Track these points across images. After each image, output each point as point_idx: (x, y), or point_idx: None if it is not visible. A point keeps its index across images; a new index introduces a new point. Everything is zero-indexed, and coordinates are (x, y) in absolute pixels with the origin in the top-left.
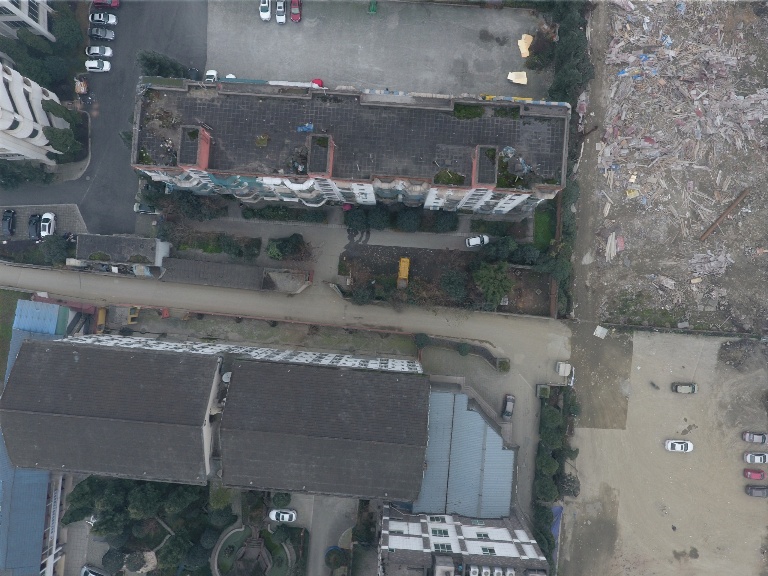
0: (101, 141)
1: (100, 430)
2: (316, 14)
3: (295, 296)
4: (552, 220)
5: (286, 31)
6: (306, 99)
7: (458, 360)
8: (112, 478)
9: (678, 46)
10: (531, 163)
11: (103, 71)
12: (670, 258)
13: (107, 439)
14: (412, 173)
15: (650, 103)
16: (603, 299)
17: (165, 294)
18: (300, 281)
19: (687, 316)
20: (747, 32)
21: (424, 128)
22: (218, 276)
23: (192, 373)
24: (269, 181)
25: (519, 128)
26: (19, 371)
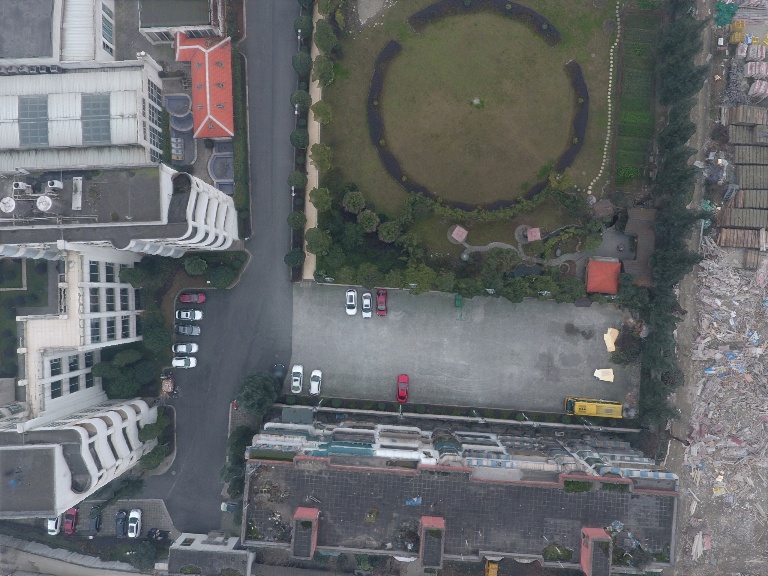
0: (187, 436)
1: None
2: (401, 307)
3: None
4: None
5: (371, 324)
6: None
7: None
8: None
9: (765, 342)
10: (639, 538)
11: (189, 367)
12: (756, 557)
13: None
14: (520, 547)
15: (736, 399)
16: None
17: None
18: None
19: None
20: None
21: (532, 502)
22: None
23: None
24: None
25: (627, 502)
26: None
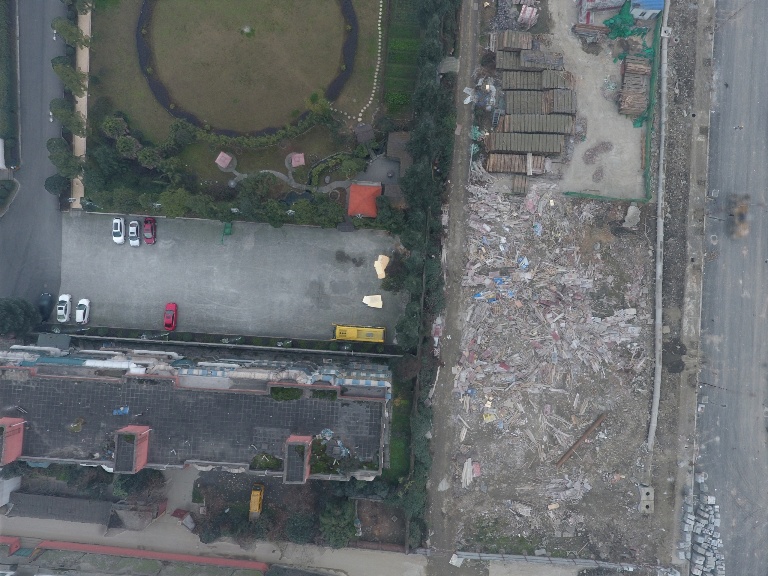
0: None
1: None
2: (171, 236)
3: None
4: (407, 447)
5: (141, 253)
6: None
7: None
8: None
9: (535, 267)
10: (349, 446)
11: None
12: (527, 483)
13: None
14: (229, 456)
15: (507, 325)
16: (459, 526)
17: (17, 523)
18: (147, 519)
19: (544, 544)
20: (604, 252)
21: (241, 410)
22: (66, 511)
23: None
24: None
25: (337, 410)
26: None
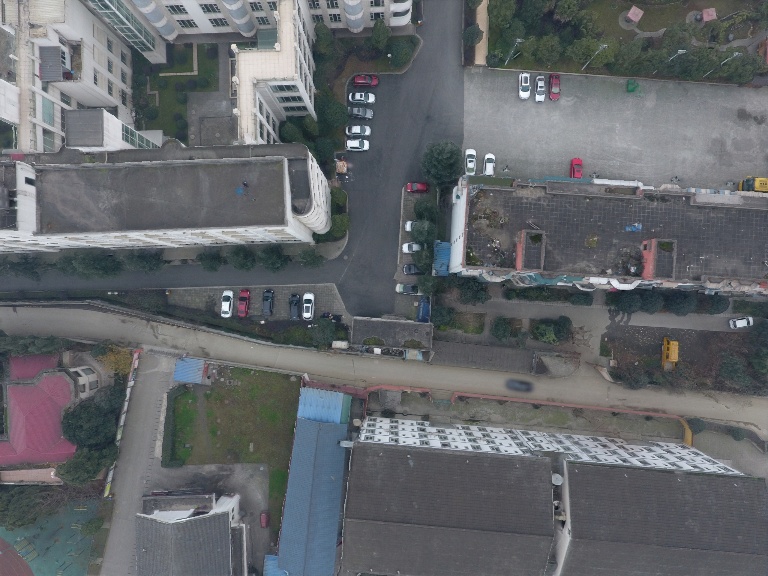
0: (359, 220)
1: (447, 539)
2: (573, 92)
3: None
4: None
5: (543, 109)
6: (635, 199)
7: (724, 443)
8: None
9: None
10: None
11: (362, 150)
12: None
13: (451, 547)
14: (741, 273)
15: None
16: None
17: (426, 375)
18: (573, 365)
19: None
20: None
21: (753, 228)
22: (487, 359)
23: (529, 478)
24: (595, 280)
25: None
26: (358, 477)
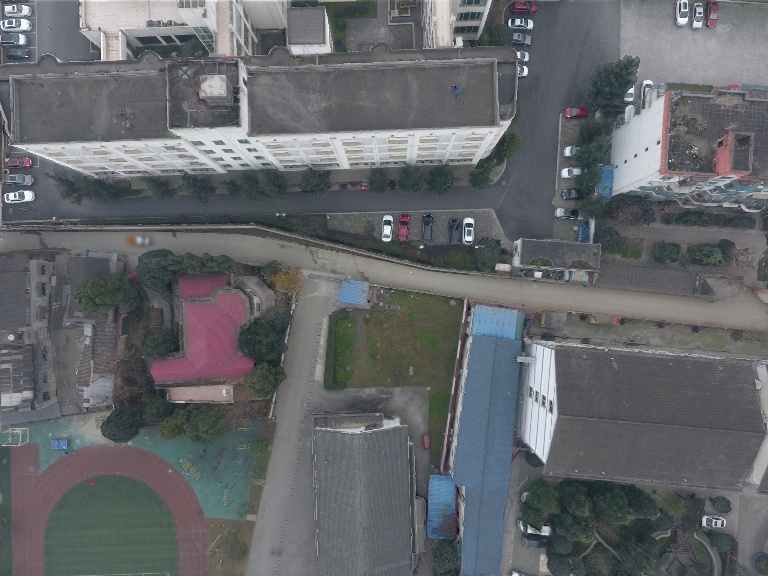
0: None
1: (658, 437)
2: (729, 20)
3: (716, 302)
4: None
5: (699, 37)
6: None
7: None
8: (558, 484)
9: None
10: None
11: (521, 76)
12: None
13: (661, 446)
14: None
15: None
16: None
17: (584, 299)
18: (738, 287)
19: None
20: None
21: None
22: (650, 281)
23: (733, 380)
24: None
25: None
26: (565, 377)
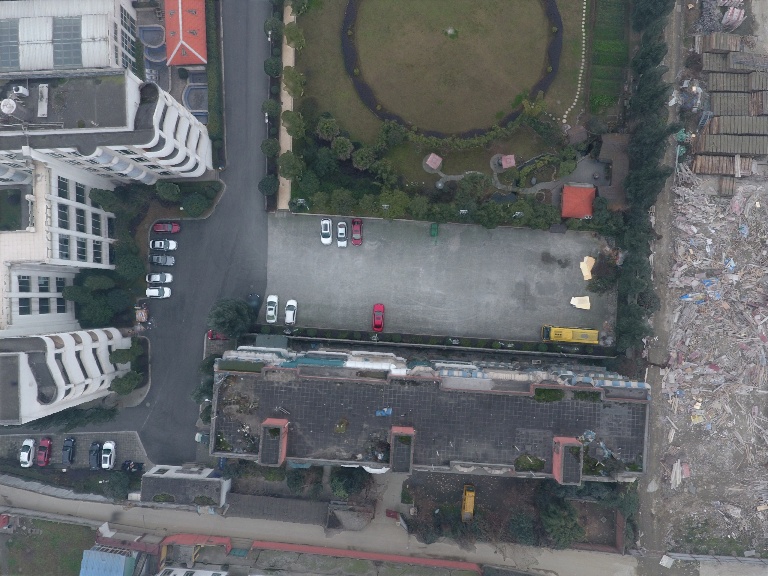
0: (161, 367)
1: None
2: (377, 237)
3: None
4: None
5: (347, 254)
6: None
7: None
8: None
9: (741, 269)
10: (612, 447)
11: (163, 297)
12: (736, 485)
13: None
14: (492, 457)
15: (714, 327)
16: (669, 527)
17: (227, 523)
18: (366, 519)
19: (754, 545)
20: None
21: (503, 411)
22: (282, 512)
23: None
24: None
25: (599, 411)
26: None
